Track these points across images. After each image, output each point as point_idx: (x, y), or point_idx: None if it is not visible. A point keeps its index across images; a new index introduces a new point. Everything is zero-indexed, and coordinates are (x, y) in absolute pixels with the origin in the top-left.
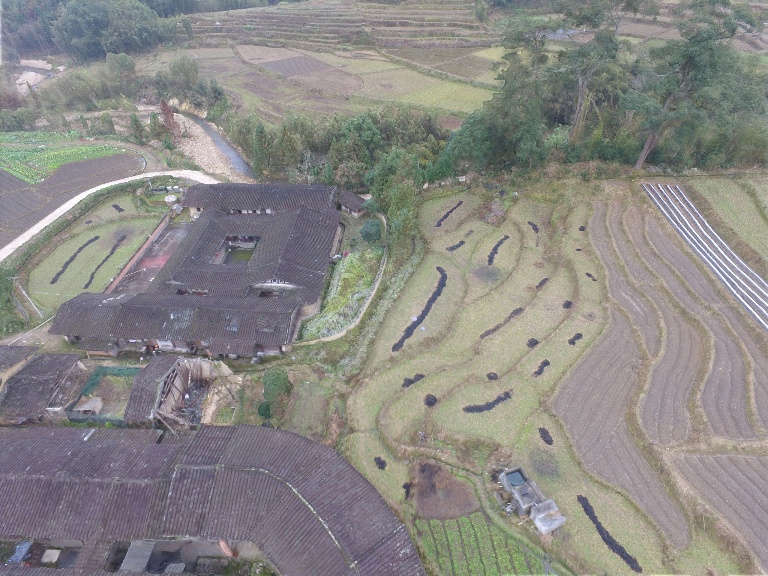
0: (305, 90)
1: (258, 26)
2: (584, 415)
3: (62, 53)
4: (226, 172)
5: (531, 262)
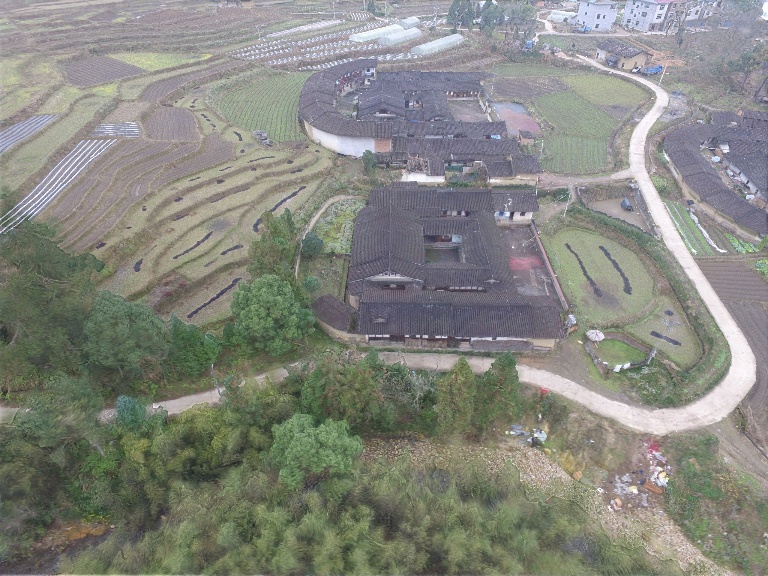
0: None
1: None
2: (220, 153)
3: None
4: (643, 544)
5: (175, 232)
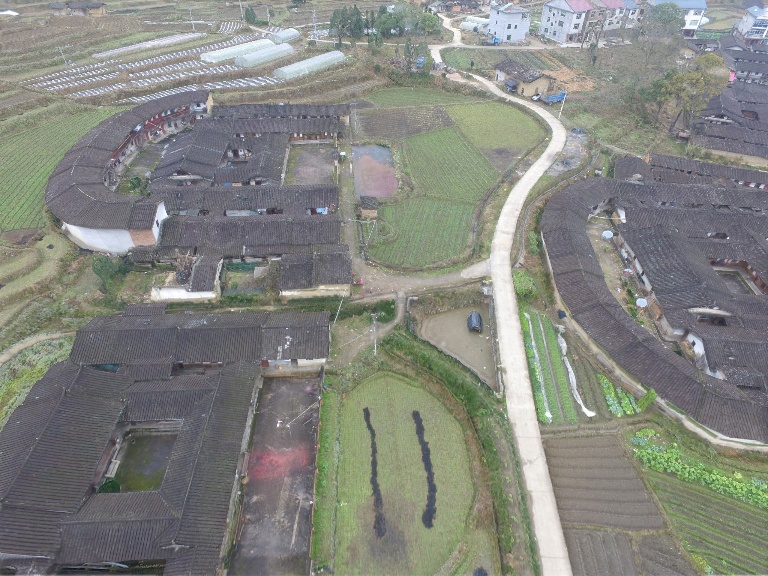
0: None
1: None
2: None
3: None
4: None
5: None
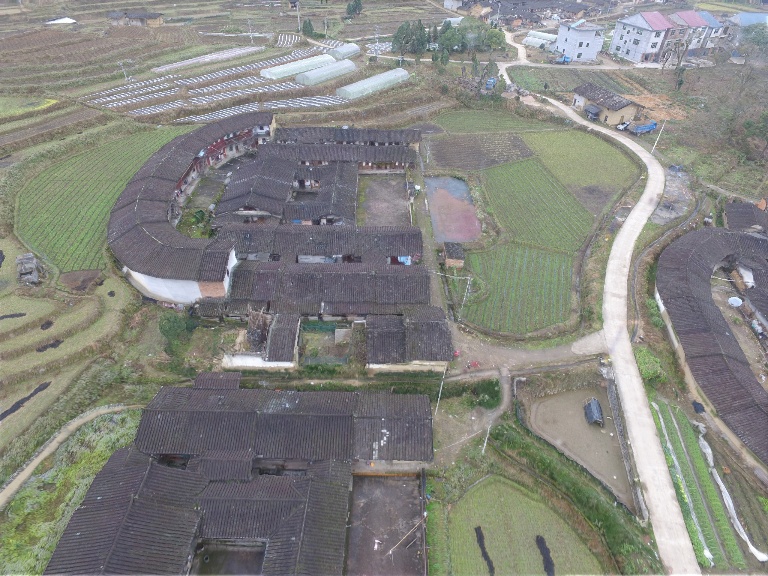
0: None
1: None
2: None
3: None
4: None
5: None
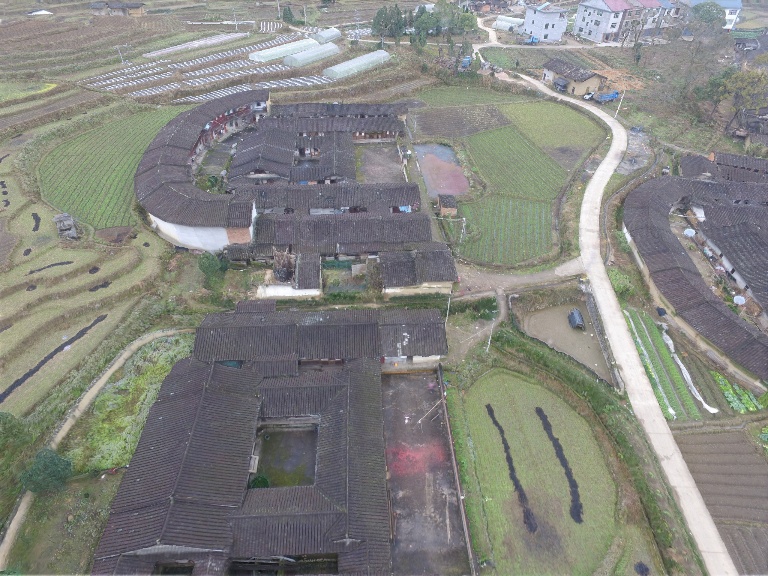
0: None
1: None
2: None
3: None
4: None
5: None
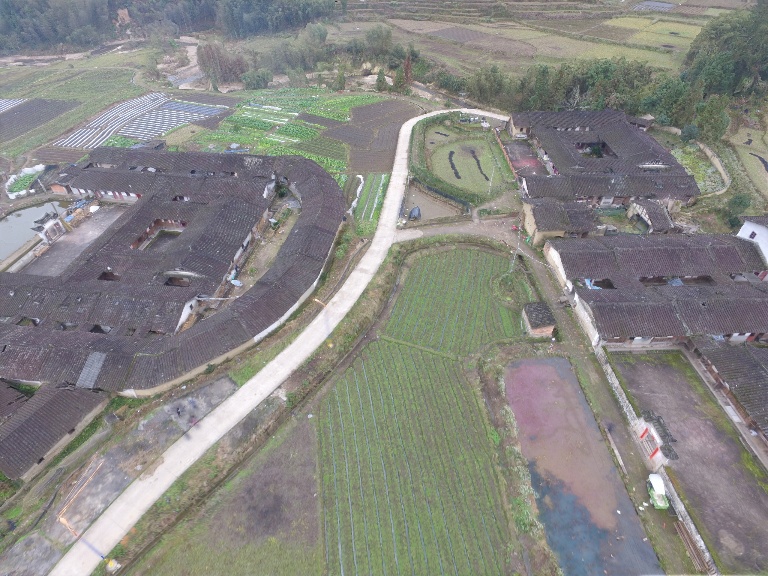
0: (490, 52)
1: (401, 2)
2: None
3: (201, 30)
4: None
5: None
